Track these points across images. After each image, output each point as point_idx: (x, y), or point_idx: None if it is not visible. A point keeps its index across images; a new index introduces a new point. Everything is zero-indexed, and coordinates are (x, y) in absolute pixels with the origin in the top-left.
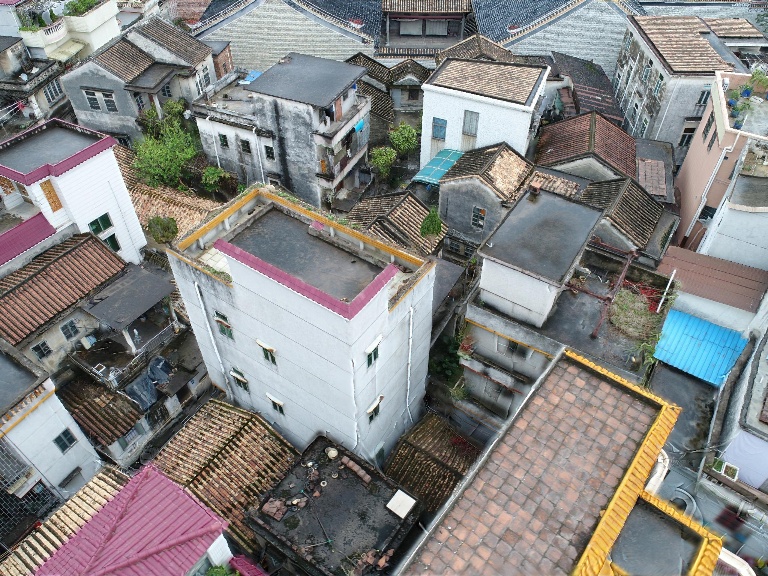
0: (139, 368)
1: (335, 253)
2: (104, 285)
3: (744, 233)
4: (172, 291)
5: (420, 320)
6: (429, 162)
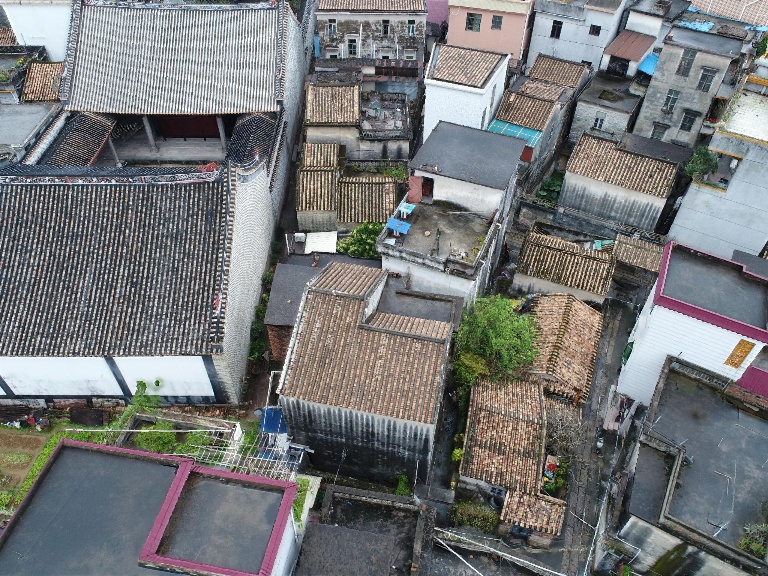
0: None
1: None
2: None
3: (613, 22)
4: (740, 251)
5: None
6: None
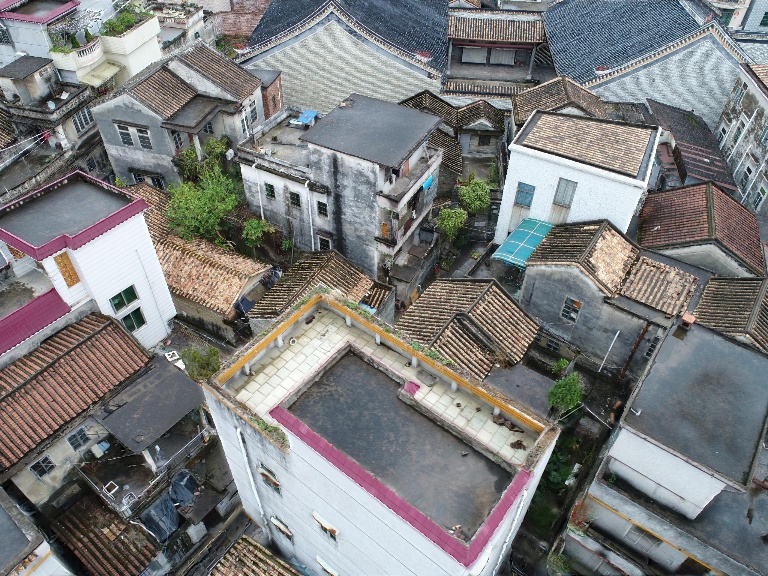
0: (159, 490)
1: (438, 437)
2: (123, 385)
3: None
4: (204, 399)
5: (528, 493)
6: (511, 235)
